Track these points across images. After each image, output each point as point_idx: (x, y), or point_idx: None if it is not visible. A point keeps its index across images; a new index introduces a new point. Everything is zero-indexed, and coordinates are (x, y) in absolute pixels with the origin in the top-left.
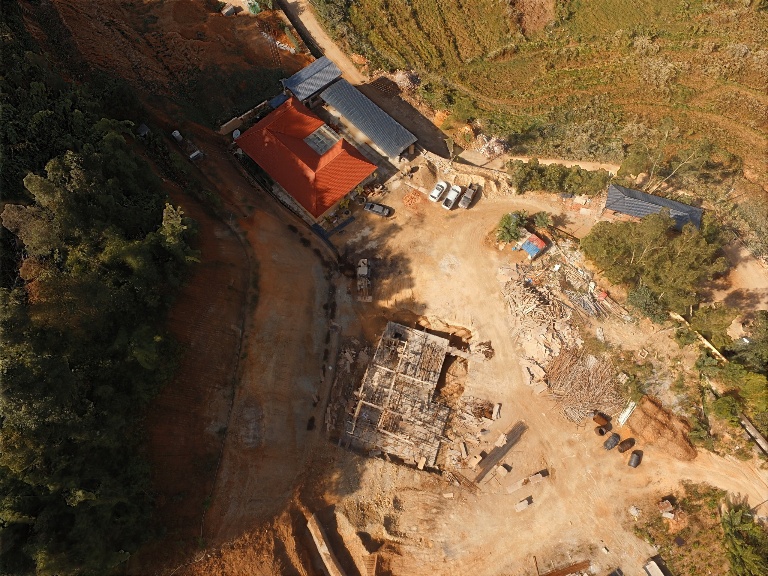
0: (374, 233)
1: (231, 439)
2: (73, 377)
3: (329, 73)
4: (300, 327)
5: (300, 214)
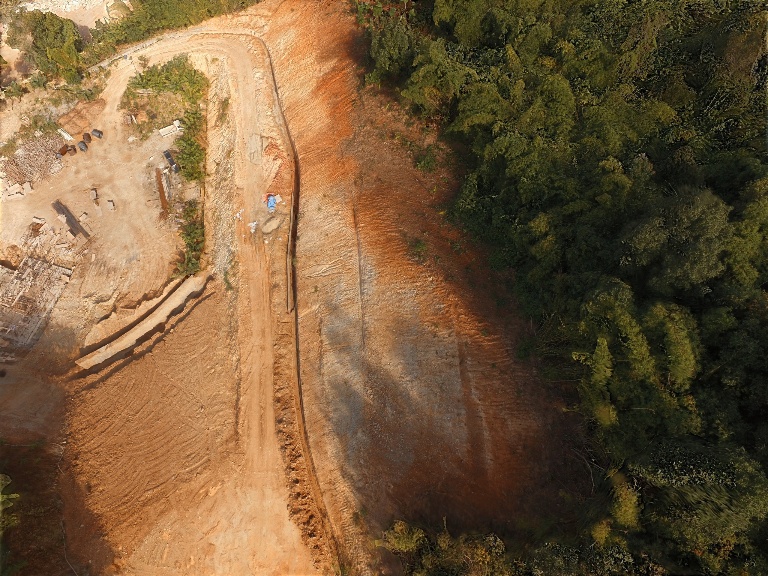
0: None
1: None
2: None
3: None
4: None
5: None
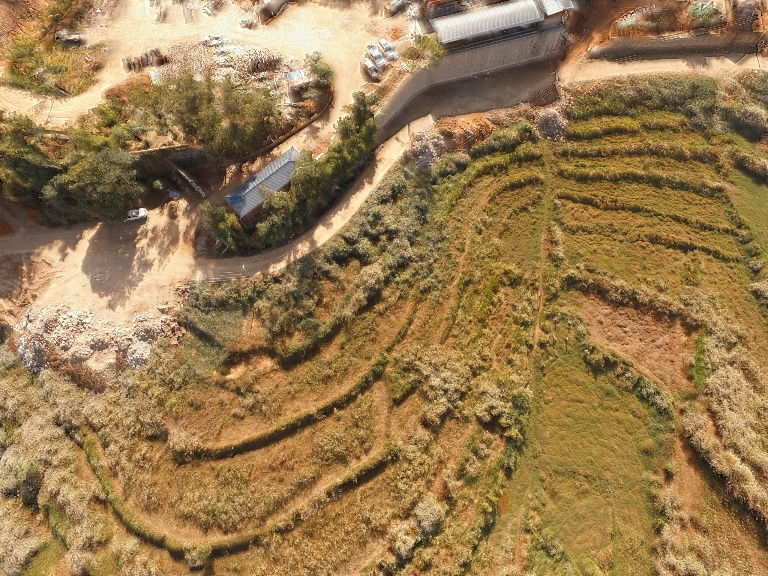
0: None
1: None
2: None
3: (548, 2)
4: None
5: None
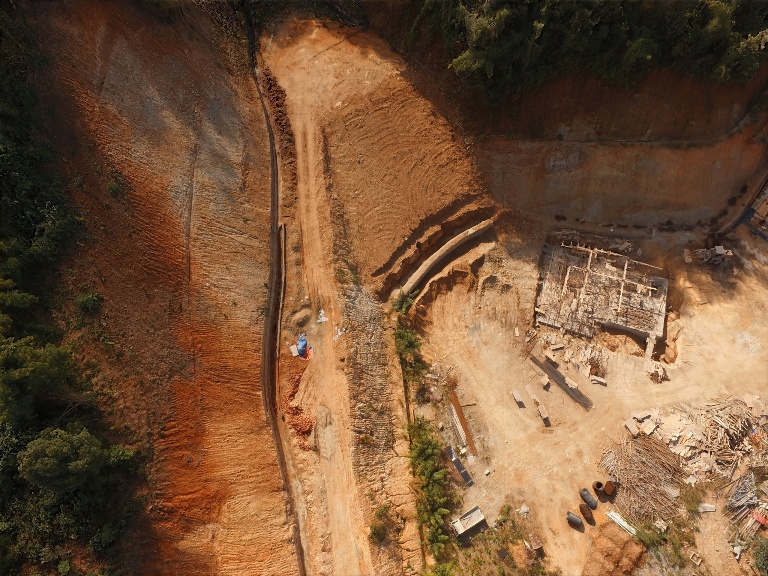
0: (762, 265)
1: (554, 146)
2: (619, 3)
3: None
4: (649, 198)
5: (762, 196)
